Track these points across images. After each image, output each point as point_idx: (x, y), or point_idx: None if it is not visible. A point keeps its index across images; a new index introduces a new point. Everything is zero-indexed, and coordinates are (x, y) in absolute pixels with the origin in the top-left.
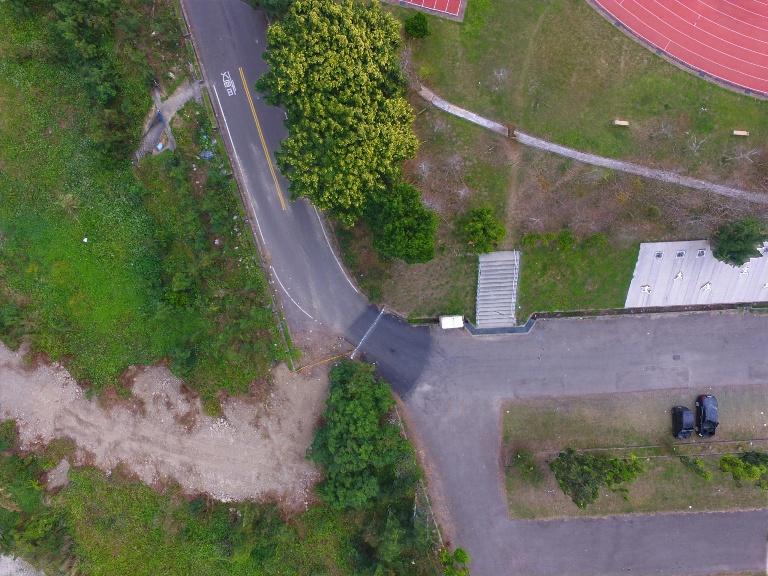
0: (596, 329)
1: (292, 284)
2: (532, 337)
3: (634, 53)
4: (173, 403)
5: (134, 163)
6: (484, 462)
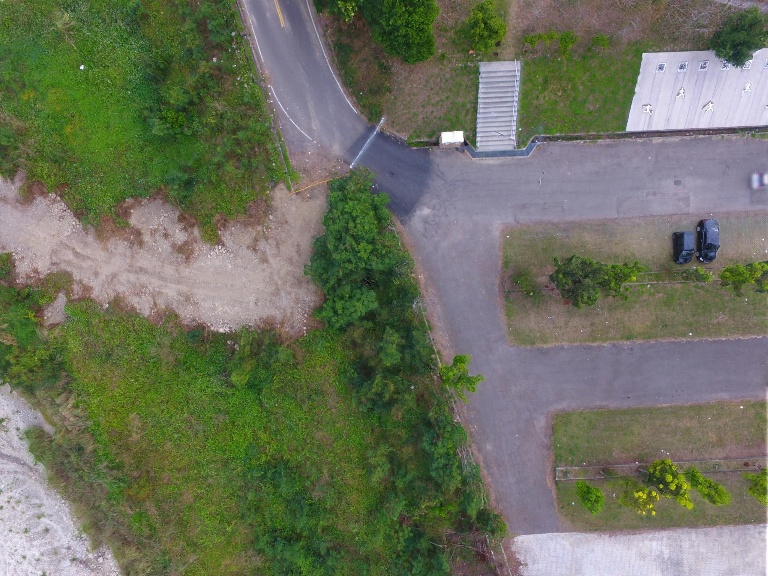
0: (597, 153)
1: (291, 104)
2: (533, 160)
3: None
4: (171, 234)
5: None
6: (484, 287)
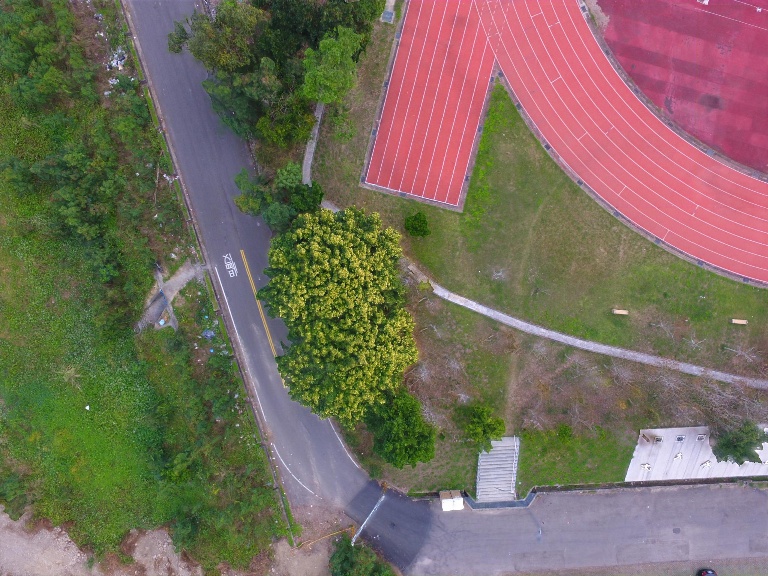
0: (596, 503)
1: (293, 460)
2: (532, 511)
3: (633, 242)
4: (174, 569)
5: (136, 331)
6: None
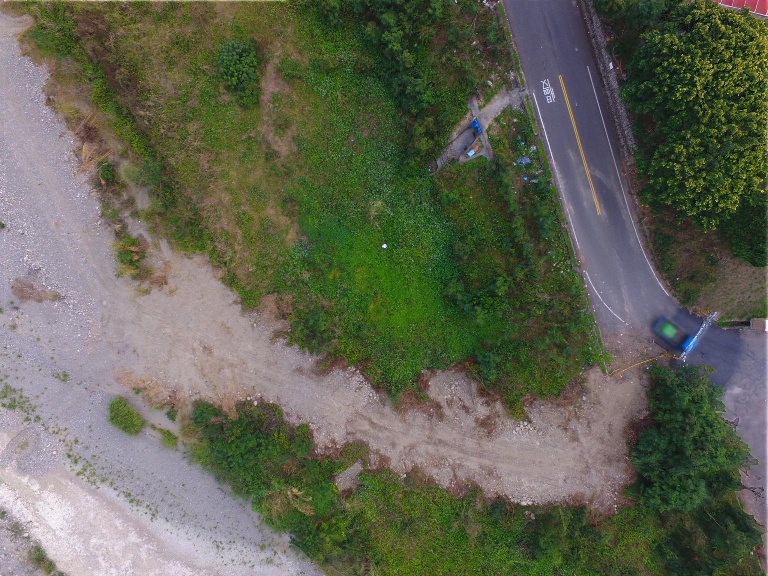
0: None
1: (605, 288)
2: None
3: None
4: (469, 407)
5: (431, 170)
6: None
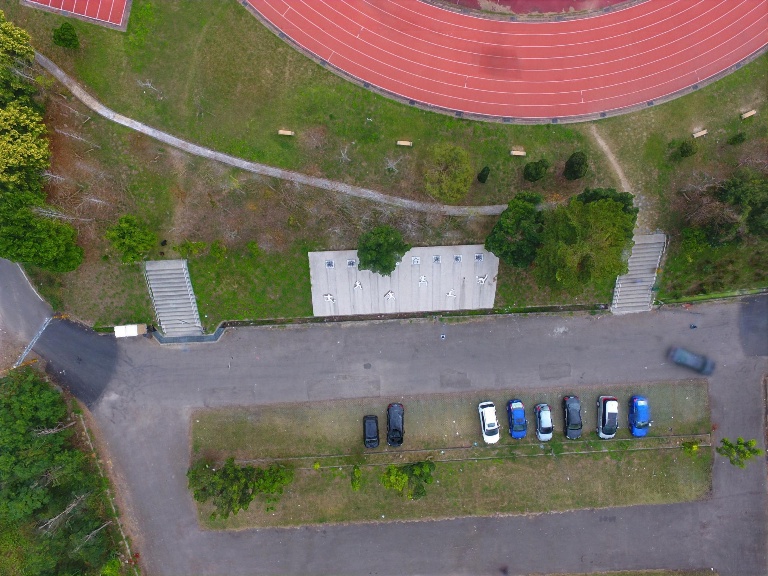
0: (286, 338)
1: None
2: (221, 346)
3: (298, 64)
4: None
5: None
6: (174, 472)
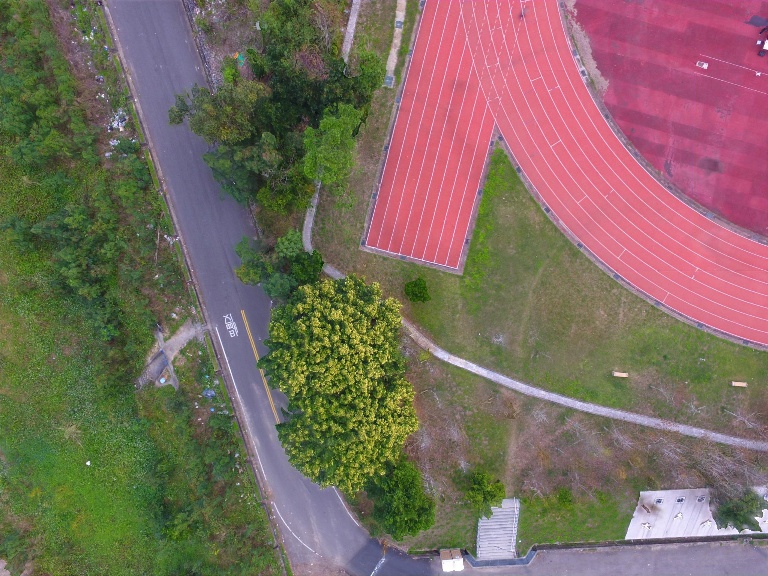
0: (596, 561)
1: (293, 519)
2: (533, 569)
3: (633, 305)
4: None
5: (137, 386)
6: None
